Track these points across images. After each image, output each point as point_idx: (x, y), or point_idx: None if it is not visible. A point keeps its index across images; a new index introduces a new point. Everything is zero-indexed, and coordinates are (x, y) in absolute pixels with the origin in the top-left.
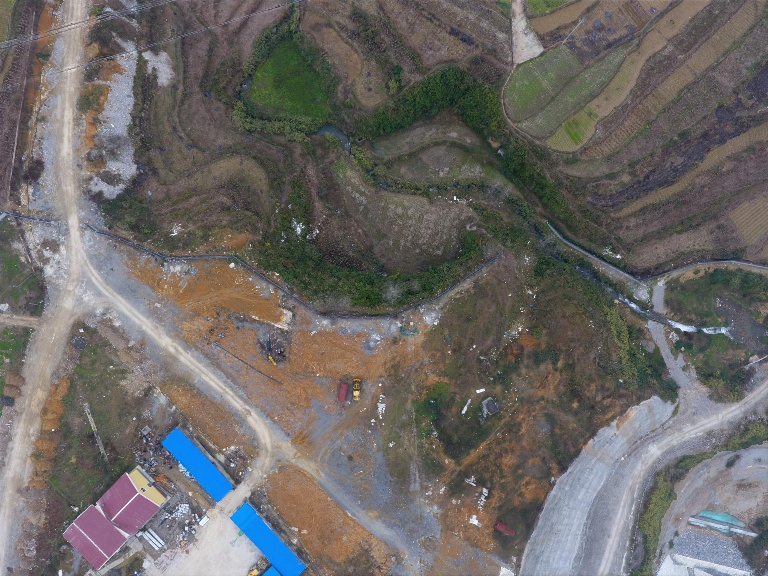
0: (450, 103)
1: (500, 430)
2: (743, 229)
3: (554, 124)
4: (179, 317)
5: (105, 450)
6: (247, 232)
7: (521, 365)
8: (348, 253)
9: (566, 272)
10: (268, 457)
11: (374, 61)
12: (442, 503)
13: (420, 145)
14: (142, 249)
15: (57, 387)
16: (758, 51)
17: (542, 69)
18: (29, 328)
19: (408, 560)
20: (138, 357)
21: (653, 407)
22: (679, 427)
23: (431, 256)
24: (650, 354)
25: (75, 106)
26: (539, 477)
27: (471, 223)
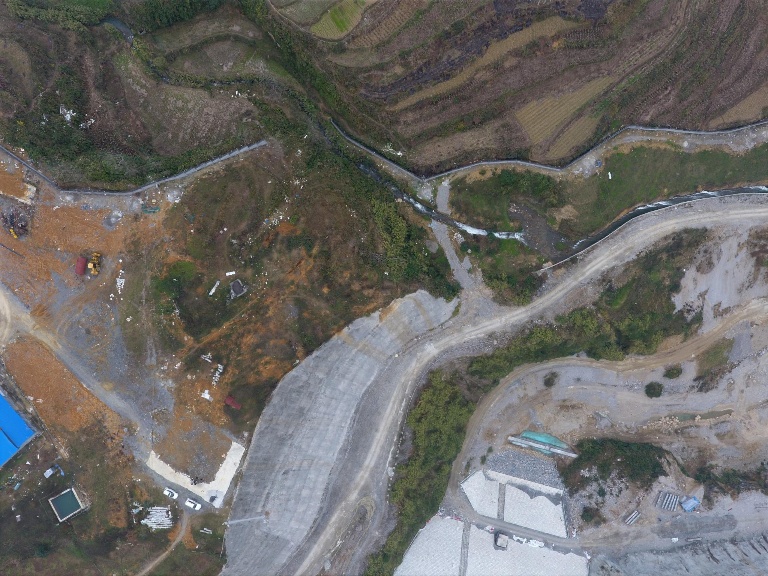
0: None
1: (246, 312)
2: (529, 128)
3: (318, 10)
4: None
5: None
6: None
7: (273, 250)
8: (122, 143)
9: (337, 165)
10: (7, 328)
11: None
12: (177, 378)
13: (202, 38)
14: None
15: None
16: None
17: None
18: None
19: (140, 432)
20: None
21: (421, 302)
22: (459, 327)
23: None
24: (433, 254)
25: None
26: (281, 358)
27: (249, 116)
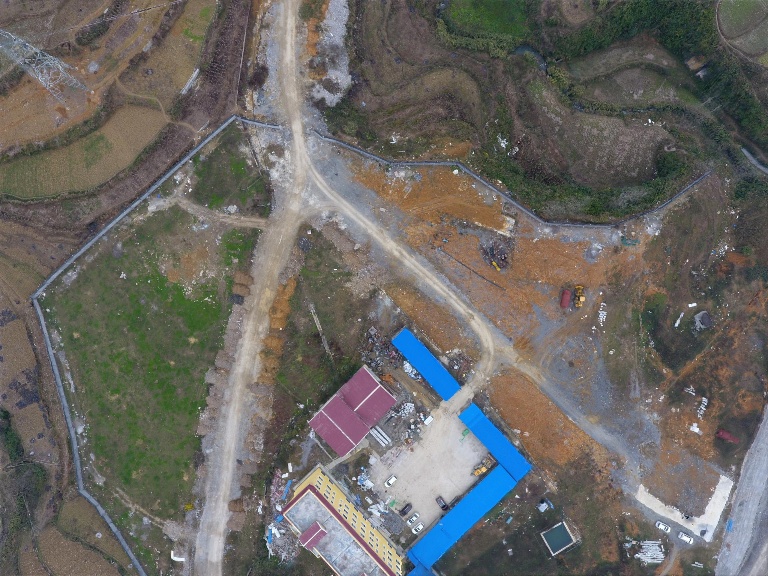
0: (651, 23)
1: (714, 343)
2: None
3: (767, 41)
4: (403, 222)
5: (330, 350)
6: (468, 141)
7: (732, 281)
8: (547, 171)
9: (767, 194)
10: (491, 360)
11: None
12: (662, 411)
13: (617, 66)
14: (369, 154)
15: (285, 287)
16: None
17: None
18: (258, 229)
19: (628, 465)
20: (364, 259)
21: None
22: None
23: (626, 178)
24: None
25: (298, 14)
26: (754, 390)
27: (668, 145)
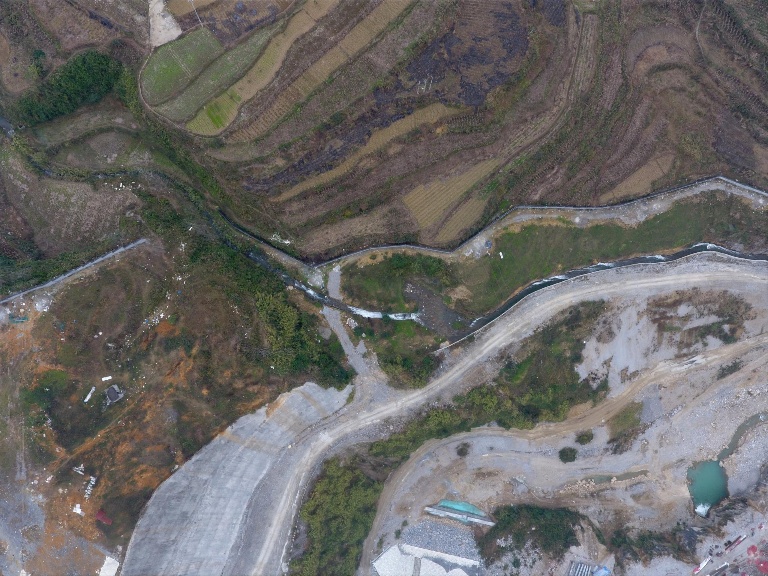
0: (109, 88)
1: (122, 418)
2: (417, 213)
3: (193, 107)
4: None
5: None
6: None
7: (151, 352)
8: (1, 241)
9: (221, 258)
10: None
11: (21, 46)
12: (48, 492)
13: (84, 131)
14: None
15: None
16: (416, 32)
17: (181, 52)
18: None
19: (10, 550)
20: None
21: (310, 394)
22: (354, 414)
23: (93, 244)
24: (326, 341)
25: None
26: (158, 465)
27: (132, 210)
